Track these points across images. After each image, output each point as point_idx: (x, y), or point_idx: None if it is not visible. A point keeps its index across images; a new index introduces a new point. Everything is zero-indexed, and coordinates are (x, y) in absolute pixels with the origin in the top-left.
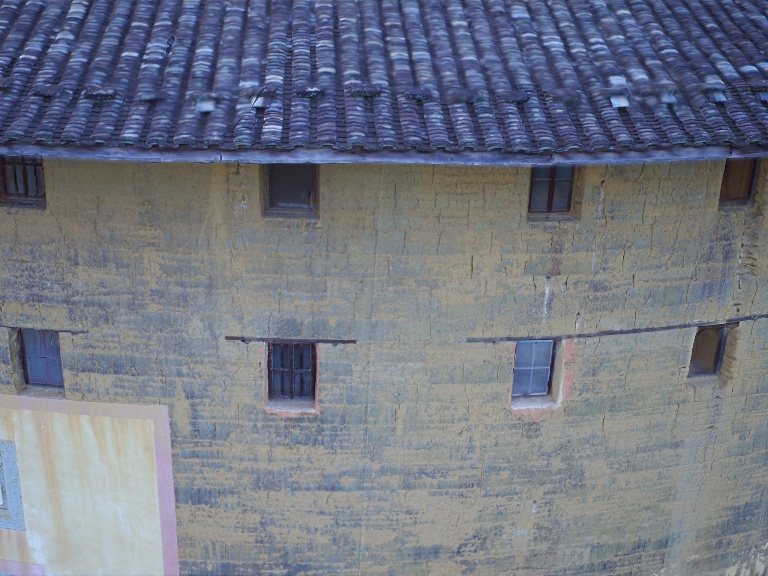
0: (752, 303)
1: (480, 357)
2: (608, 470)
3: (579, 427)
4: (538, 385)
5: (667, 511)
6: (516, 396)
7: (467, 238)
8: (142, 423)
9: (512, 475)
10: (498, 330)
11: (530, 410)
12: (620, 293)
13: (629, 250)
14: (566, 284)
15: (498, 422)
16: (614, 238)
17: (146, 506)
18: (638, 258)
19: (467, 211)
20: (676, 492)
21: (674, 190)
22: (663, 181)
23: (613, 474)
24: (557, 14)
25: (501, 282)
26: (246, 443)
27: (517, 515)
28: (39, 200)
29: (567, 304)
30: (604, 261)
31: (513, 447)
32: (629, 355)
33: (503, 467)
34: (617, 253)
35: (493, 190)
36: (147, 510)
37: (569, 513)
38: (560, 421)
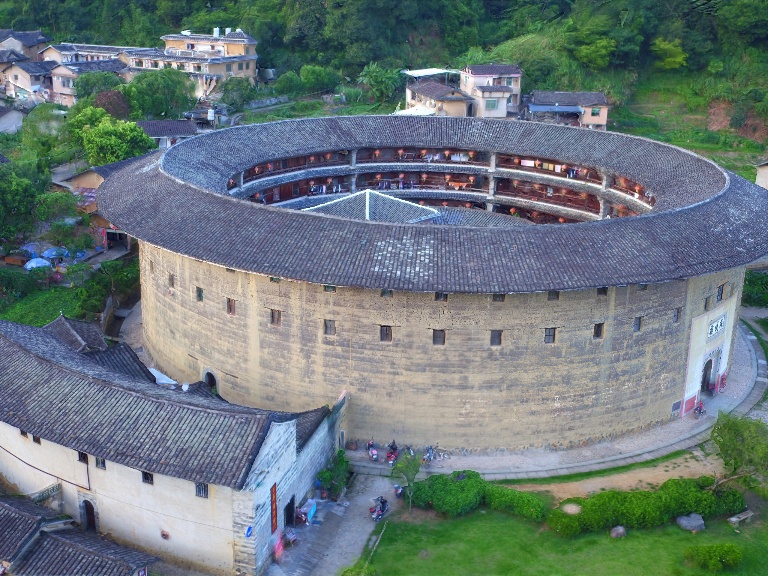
0: None
1: None
2: None
3: None
4: None
5: None
6: None
7: None
8: None
9: None
10: None
11: None
12: None
13: None
14: None
15: None
16: None
17: None
18: None
19: None
20: None
21: None
22: None
23: None
24: (766, 202)
25: None
26: None
27: None
28: None
29: None
30: None
31: None
32: None
33: None
34: None
35: None
36: None
37: None
38: None
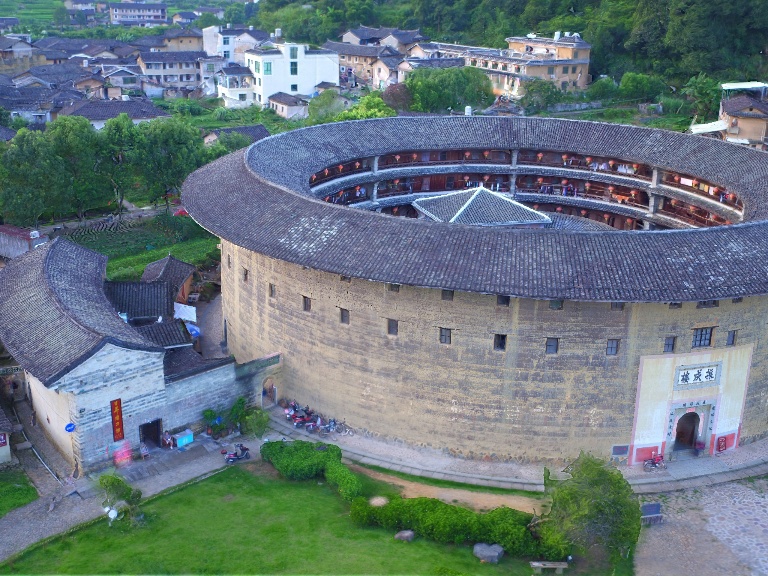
0: None
1: None
2: None
3: None
4: None
5: None
6: None
7: None
8: (749, 348)
9: None
10: None
11: None
12: None
13: None
14: None
15: None
16: None
17: (745, 370)
18: None
19: None
20: None
21: None
22: None
23: None
24: None
25: None
26: (765, 348)
27: None
28: (738, 300)
29: None
30: None
31: None
32: None
33: None
34: None
35: None
36: (745, 371)
37: None
38: None
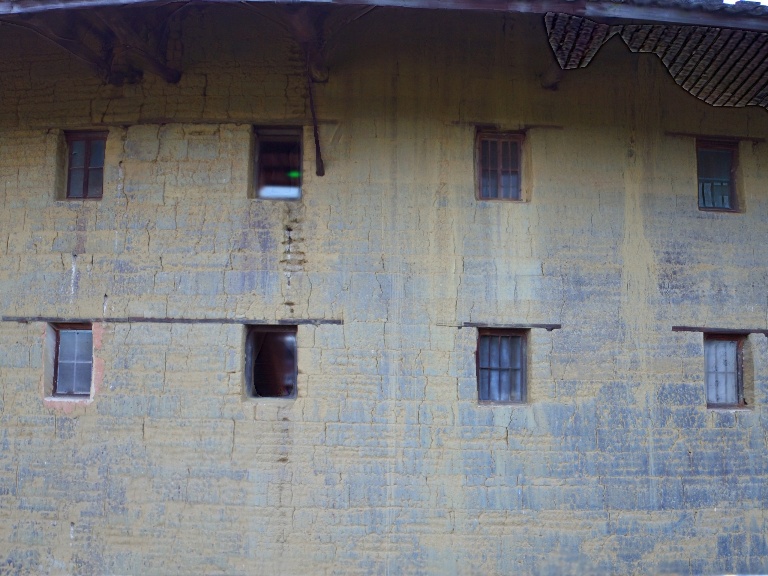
0: (308, 304)
1: (14, 338)
2: (155, 495)
3: (116, 431)
4: (82, 383)
5: (240, 571)
6: (61, 394)
7: (4, 216)
8: None
9: (47, 484)
10: (29, 309)
11: (63, 403)
12: (147, 276)
13: (153, 231)
14: (92, 263)
15: (31, 415)
16: (136, 217)
17: None
18: (164, 240)
19: (5, 191)
20: (248, 545)
21: (195, 173)
22: (182, 163)
23: (162, 501)
24: None
25: (32, 259)
26: None
27: (54, 539)
28: None
29: (94, 284)
30: (128, 241)
31: (47, 448)
32: (165, 348)
33: (38, 472)
34: (140, 233)
35: (26, 172)
36: None
37: (112, 547)
38: (94, 420)
